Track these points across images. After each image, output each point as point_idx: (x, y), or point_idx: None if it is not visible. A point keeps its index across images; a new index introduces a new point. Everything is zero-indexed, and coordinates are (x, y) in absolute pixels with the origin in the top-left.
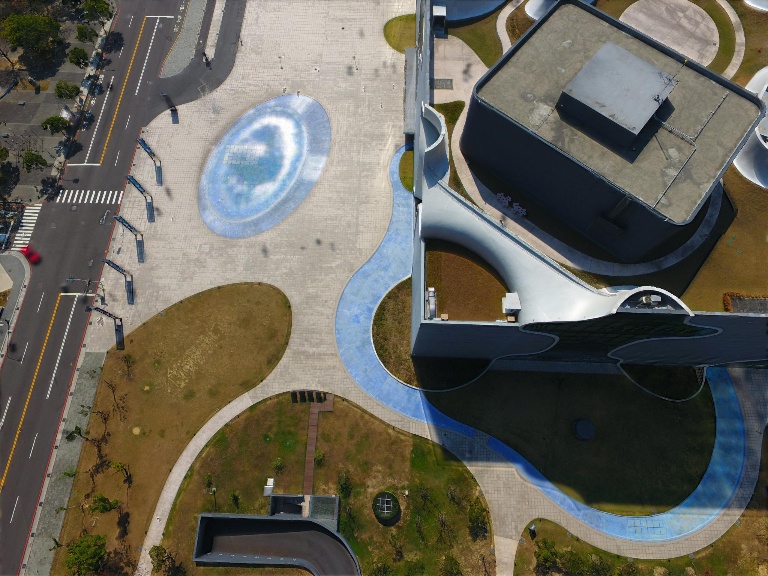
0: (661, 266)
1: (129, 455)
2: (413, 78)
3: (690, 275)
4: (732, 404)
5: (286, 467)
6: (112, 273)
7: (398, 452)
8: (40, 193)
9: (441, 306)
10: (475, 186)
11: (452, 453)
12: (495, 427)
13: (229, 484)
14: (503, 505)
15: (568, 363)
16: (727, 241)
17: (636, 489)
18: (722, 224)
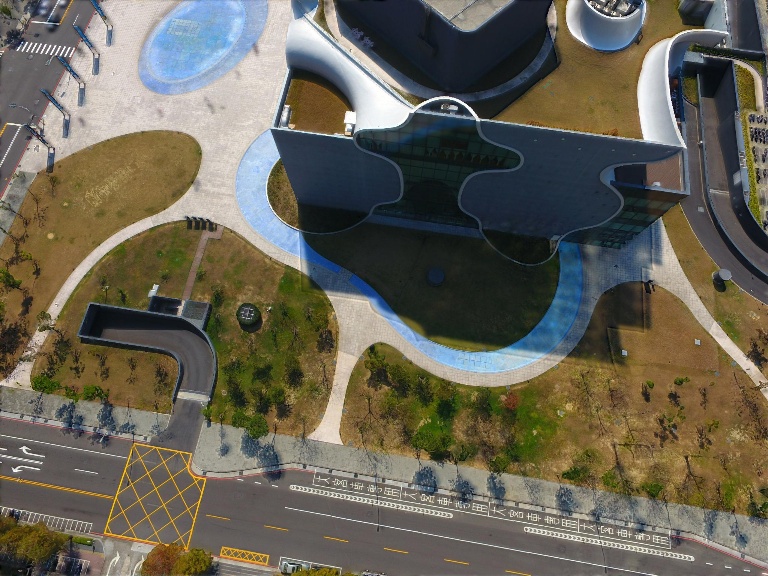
0: (479, 97)
1: (41, 254)
2: None
3: (502, 106)
4: (576, 273)
5: (171, 278)
6: (54, 112)
7: (270, 277)
8: (4, 42)
9: (293, 121)
10: (336, 22)
11: (317, 283)
12: (359, 267)
13: (120, 285)
14: (352, 329)
15: (436, 224)
16: (543, 85)
17: (472, 330)
18: (543, 71)
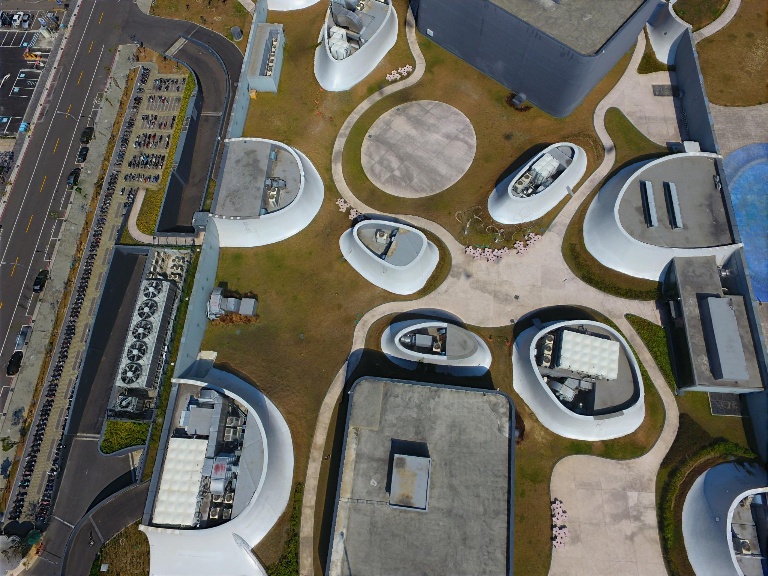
0: None
1: None
2: None
3: None
4: None
5: None
6: None
7: None
8: None
9: None
10: None
11: None
12: None
13: None
14: None
15: None
16: None
17: None
18: None
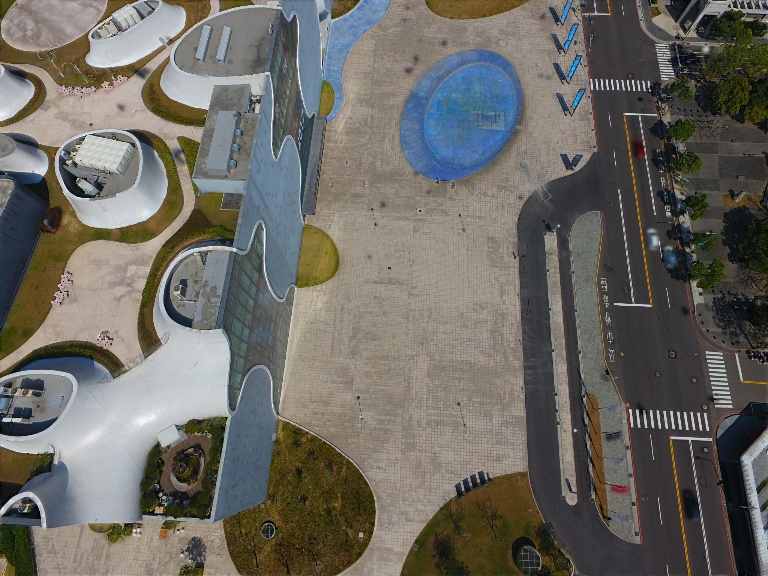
0: None
1: None
2: (310, 174)
3: None
4: None
5: None
6: None
7: None
8: None
9: None
10: None
11: None
12: None
13: None
14: None
15: None
16: None
17: None
18: None
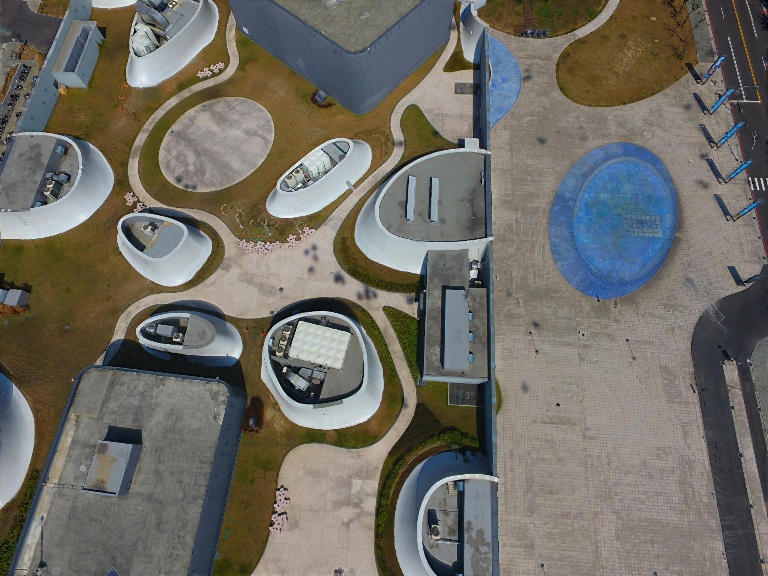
0: None
1: (652, 7)
2: None
3: None
4: None
5: (543, 1)
6: (724, 117)
7: None
8: None
9: None
10: None
11: None
12: None
13: None
14: None
15: None
16: None
17: None
18: None
